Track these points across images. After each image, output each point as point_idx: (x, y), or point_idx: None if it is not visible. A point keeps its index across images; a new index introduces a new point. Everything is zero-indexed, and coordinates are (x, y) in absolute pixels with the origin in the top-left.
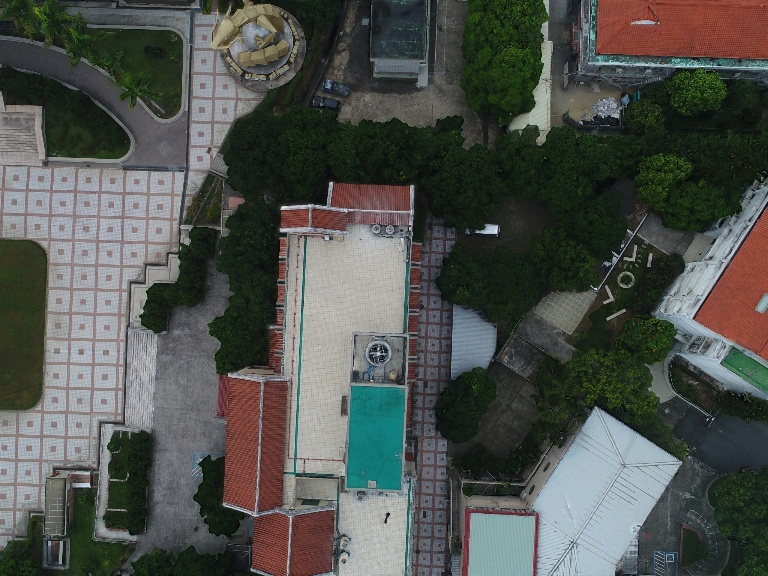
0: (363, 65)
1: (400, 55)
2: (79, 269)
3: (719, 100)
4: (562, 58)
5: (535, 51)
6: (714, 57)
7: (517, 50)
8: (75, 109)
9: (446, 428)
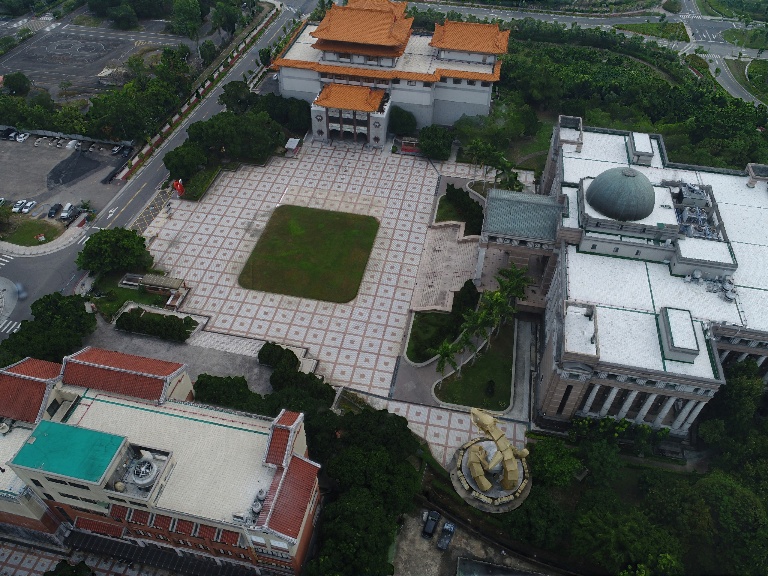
0: None
1: None
2: (327, 320)
3: None
4: None
5: None
6: None
7: None
8: None
9: (57, 570)
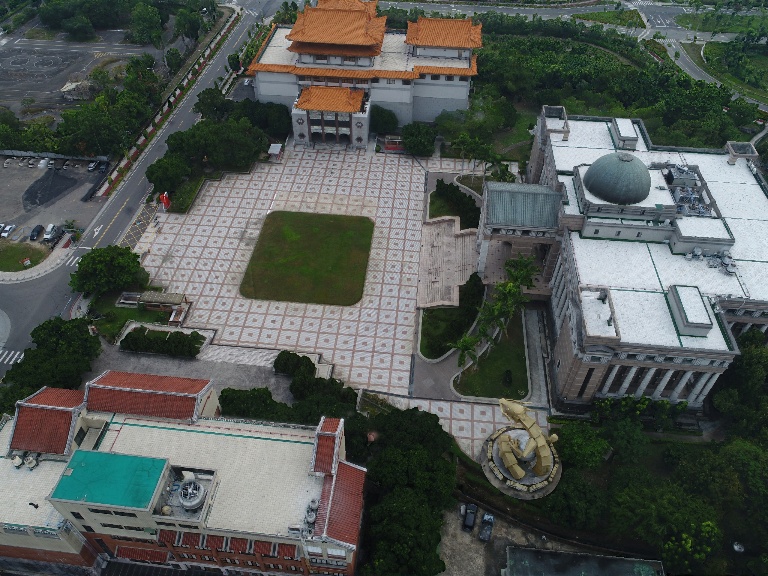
0: None
1: None
2: (336, 323)
3: None
4: None
5: None
6: None
7: None
8: (455, 322)
9: None
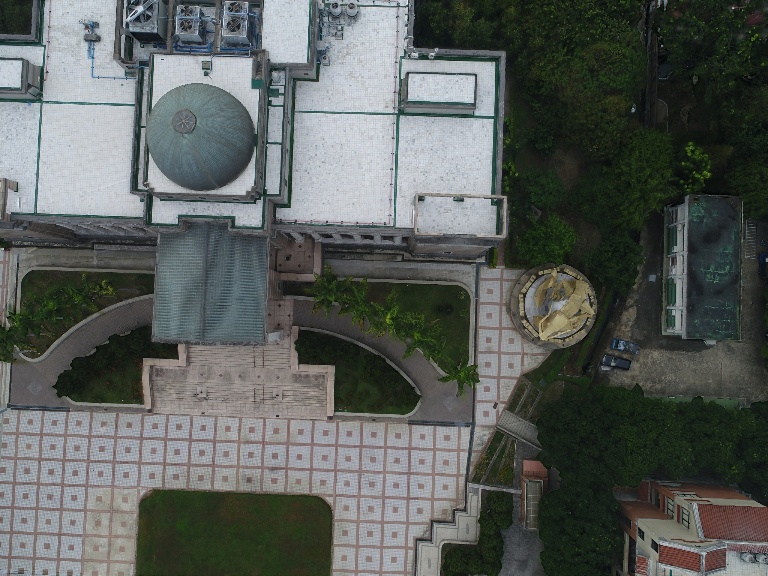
0: (651, 322)
1: (714, 334)
2: (365, 526)
3: None
4: None
5: None
6: None
7: None
8: (374, 374)
9: None
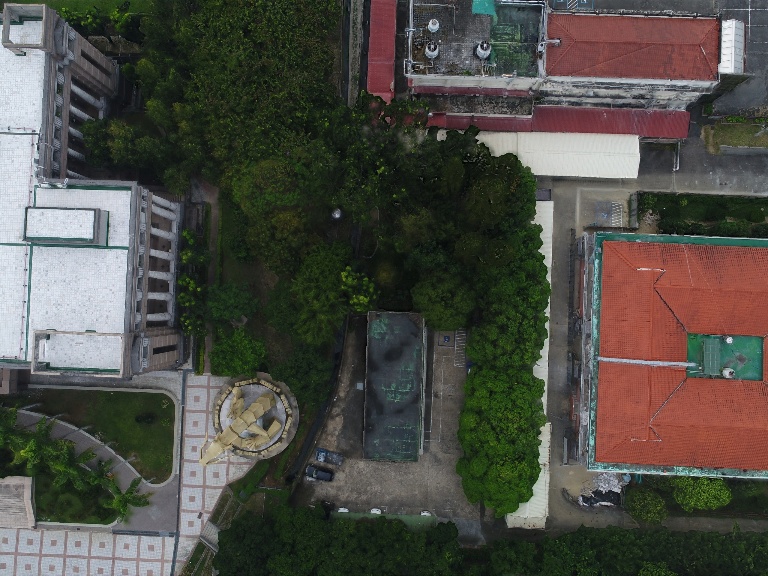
0: (357, 431)
1: (394, 454)
2: None
3: (724, 505)
4: (561, 428)
5: (532, 460)
6: (718, 467)
7: (513, 464)
8: None
9: None
